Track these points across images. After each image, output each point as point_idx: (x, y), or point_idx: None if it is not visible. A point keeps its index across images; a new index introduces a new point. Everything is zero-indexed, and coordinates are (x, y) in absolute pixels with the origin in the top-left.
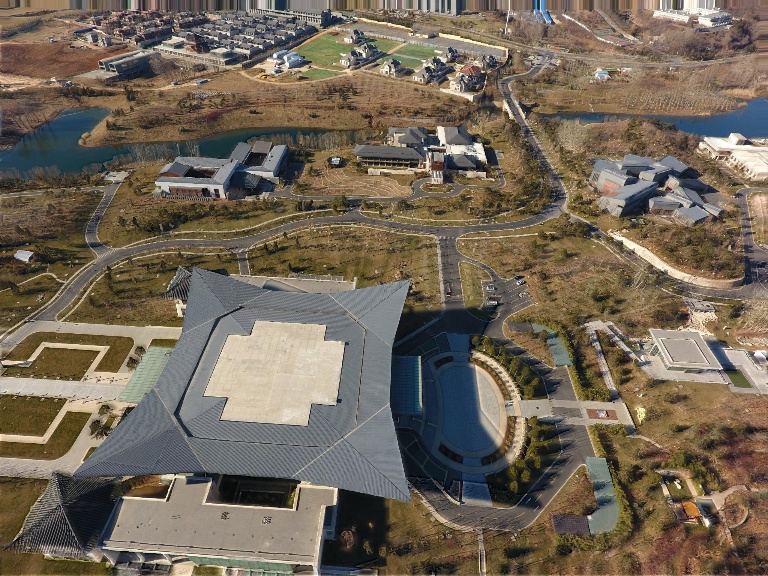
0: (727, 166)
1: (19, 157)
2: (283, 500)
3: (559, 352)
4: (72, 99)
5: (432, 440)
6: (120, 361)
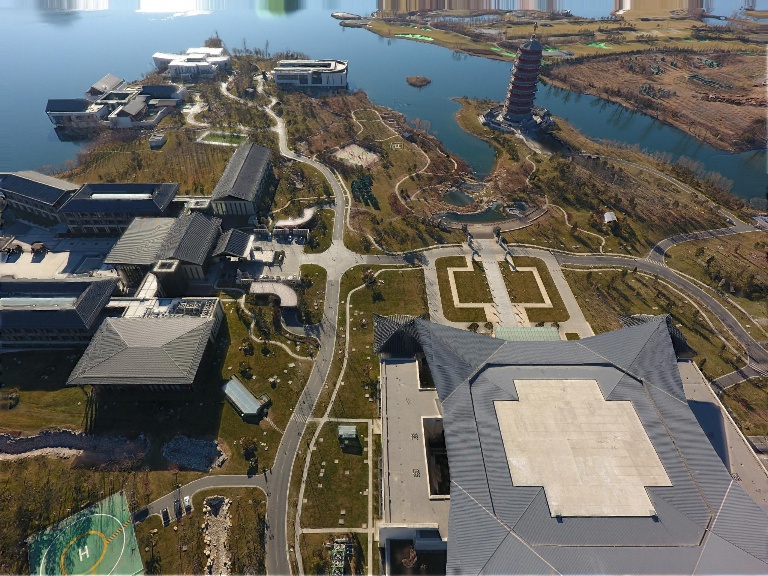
0: None
1: (736, 164)
2: (449, 494)
3: None
4: None
5: None
6: (542, 320)
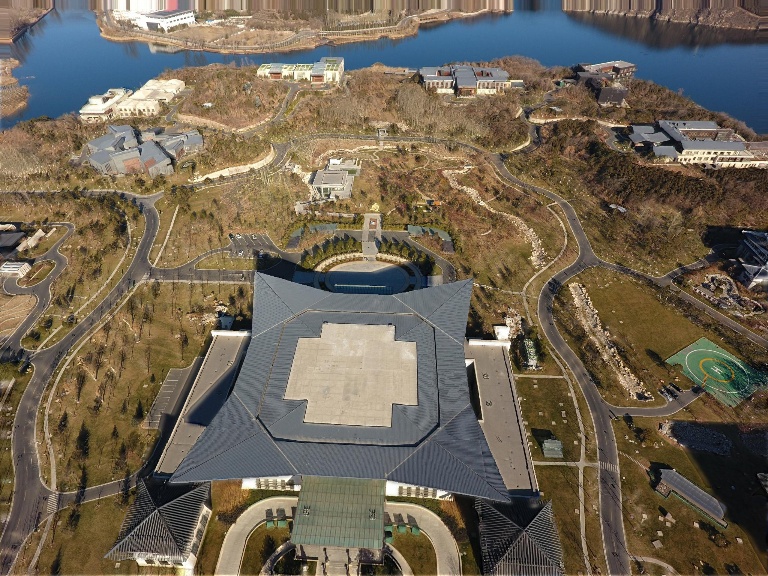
0: (125, 117)
1: None
2: None
3: (324, 227)
4: None
5: None
6: None
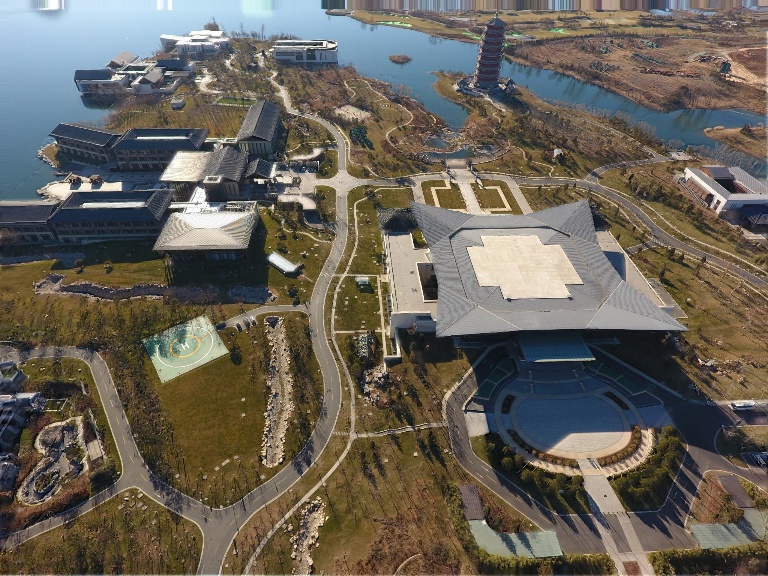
0: None
1: (667, 124)
2: None
3: (717, 534)
4: (761, 104)
5: (516, 389)
6: None
